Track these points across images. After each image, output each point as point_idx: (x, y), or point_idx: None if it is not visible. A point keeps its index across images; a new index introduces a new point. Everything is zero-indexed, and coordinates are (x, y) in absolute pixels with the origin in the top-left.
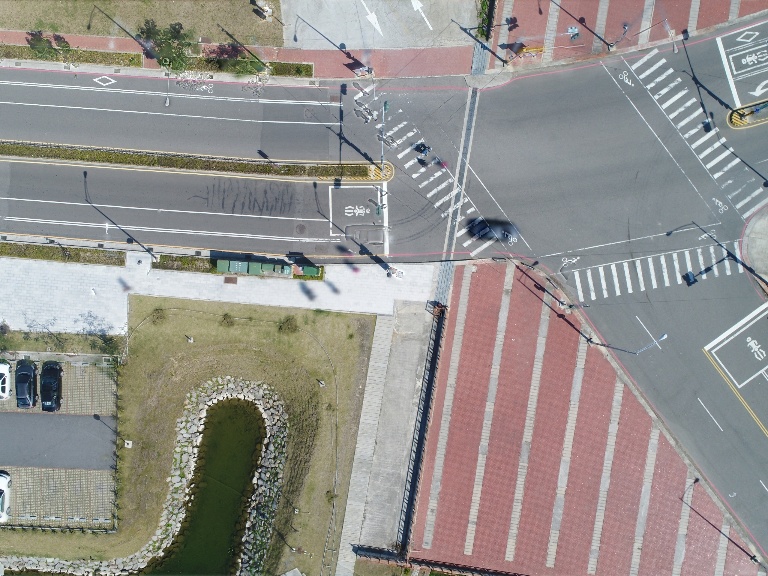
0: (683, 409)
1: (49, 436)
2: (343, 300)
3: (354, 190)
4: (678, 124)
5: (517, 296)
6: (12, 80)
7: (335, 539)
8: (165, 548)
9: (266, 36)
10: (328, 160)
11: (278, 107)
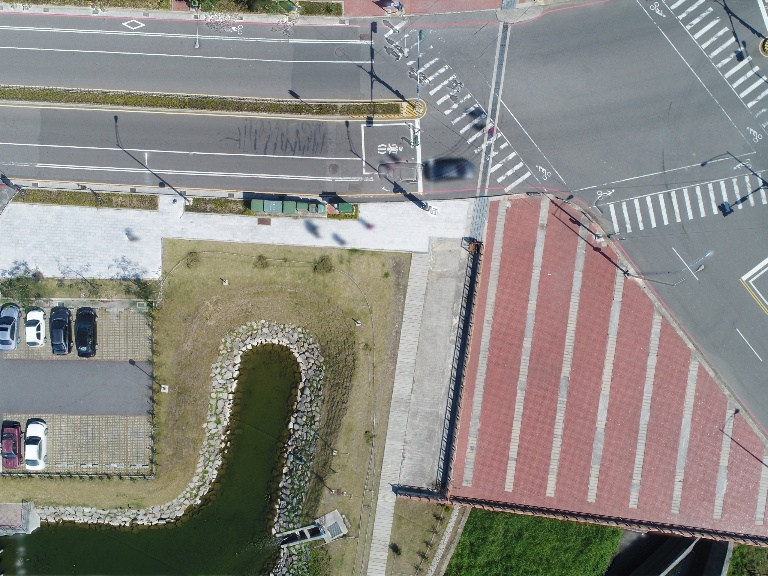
0: (722, 340)
1: (85, 383)
2: (378, 238)
3: (386, 128)
4: (711, 54)
5: (552, 230)
6: (40, 26)
7: (374, 479)
8: (202, 496)
9: None
10: (360, 98)
11: (308, 47)
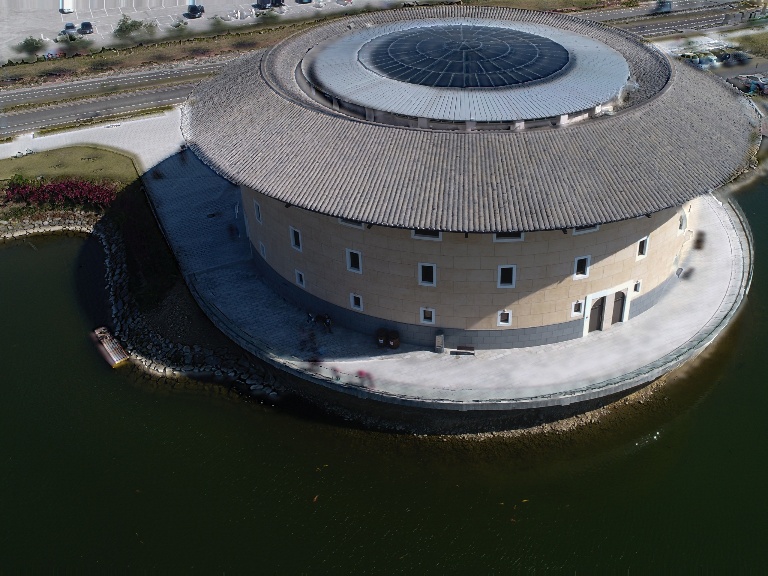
0: None
1: None
2: None
3: (741, 6)
4: None
5: None
6: None
7: None
8: None
9: None
10: None
11: None
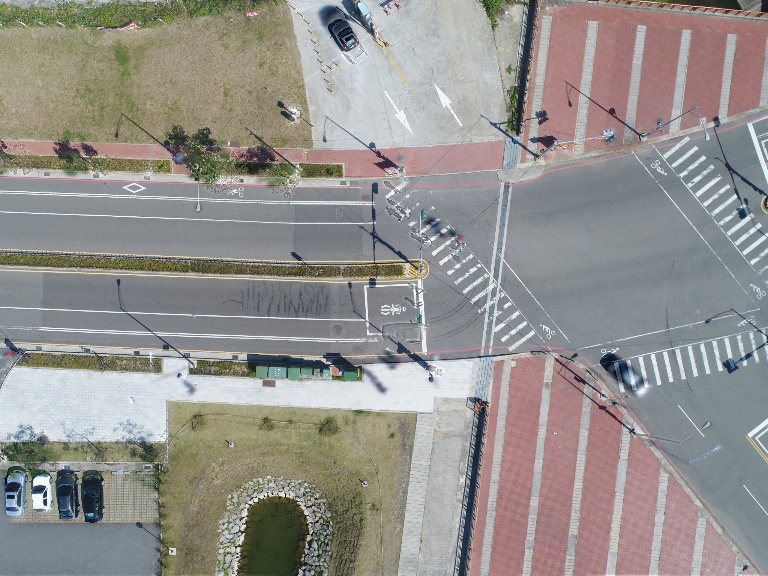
0: (729, 496)
1: (92, 546)
2: (383, 400)
3: (389, 289)
4: (713, 211)
5: (557, 389)
6: (41, 190)
7: None
8: None
9: (295, 138)
10: (362, 260)
11: (310, 208)
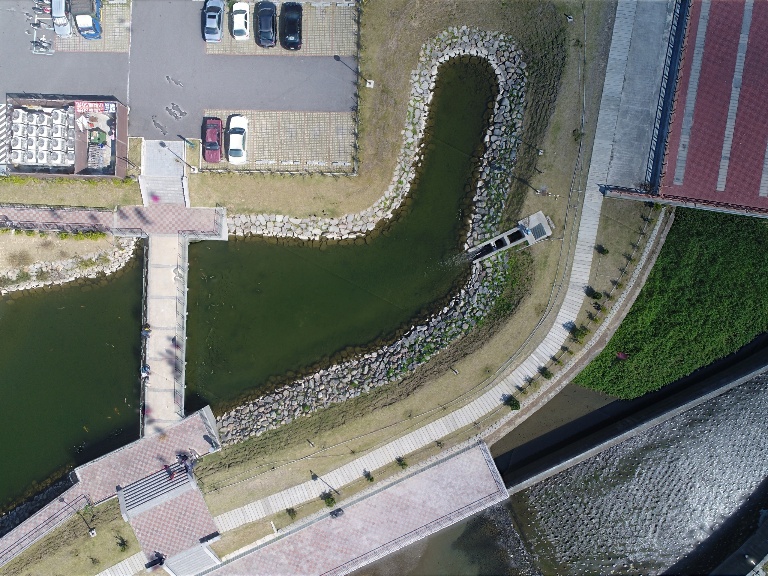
0: None
1: (288, 78)
2: None
3: None
4: None
5: None
6: None
7: (581, 179)
8: (393, 210)
9: None
10: None
11: None
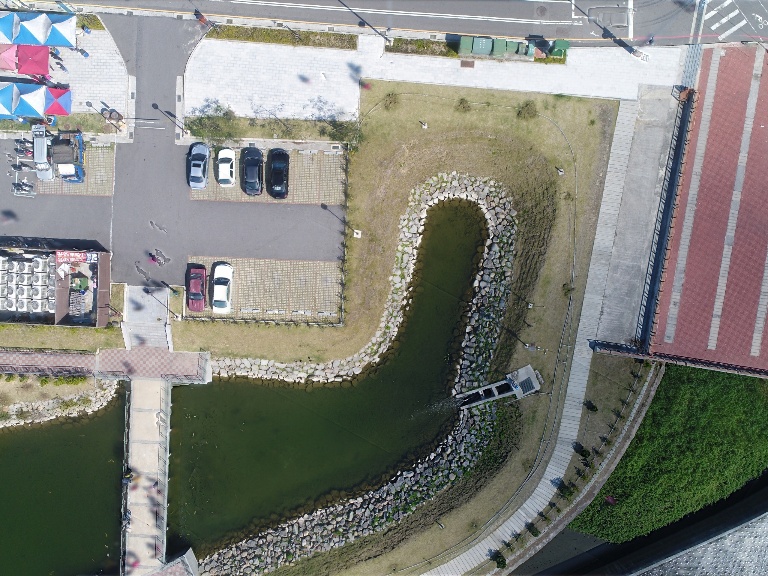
0: None
1: (274, 226)
2: (585, 84)
3: None
4: None
5: (767, 81)
6: None
7: (571, 334)
8: (380, 354)
9: None
10: None
11: None
